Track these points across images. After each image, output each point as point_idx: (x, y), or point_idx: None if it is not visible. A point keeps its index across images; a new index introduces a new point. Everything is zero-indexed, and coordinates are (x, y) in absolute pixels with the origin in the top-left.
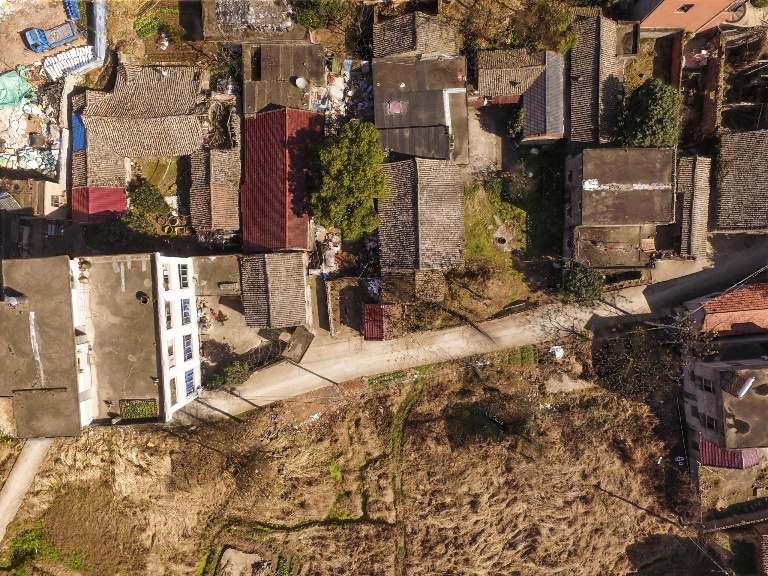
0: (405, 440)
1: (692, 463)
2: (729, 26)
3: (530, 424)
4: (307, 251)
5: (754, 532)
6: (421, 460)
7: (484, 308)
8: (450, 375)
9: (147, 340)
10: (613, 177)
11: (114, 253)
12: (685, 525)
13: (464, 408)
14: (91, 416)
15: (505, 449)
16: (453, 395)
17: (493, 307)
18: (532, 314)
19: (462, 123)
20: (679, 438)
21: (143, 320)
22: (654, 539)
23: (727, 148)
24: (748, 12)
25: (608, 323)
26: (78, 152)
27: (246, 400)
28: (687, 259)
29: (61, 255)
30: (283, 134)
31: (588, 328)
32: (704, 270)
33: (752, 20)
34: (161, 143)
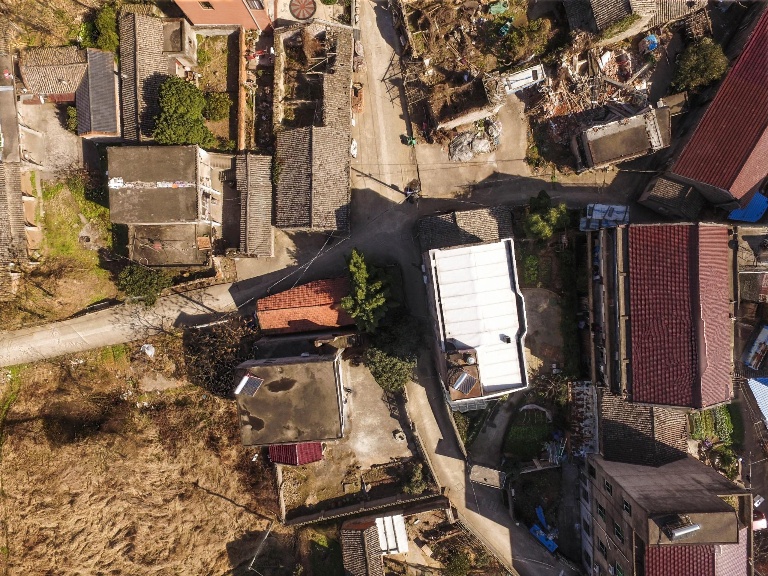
0: (4, 440)
1: None
2: None
3: (128, 423)
4: None
5: (334, 528)
6: (19, 460)
7: (61, 307)
8: (45, 374)
9: None
10: (137, 175)
11: None
12: (281, 521)
13: (62, 407)
14: None
15: (104, 448)
16: (50, 394)
17: (71, 306)
18: (121, 312)
19: (11, 121)
20: None
21: None
22: (251, 536)
23: (281, 146)
24: (318, 9)
25: (196, 321)
26: None
27: None
28: (251, 257)
29: None
30: None
31: (177, 326)
32: (287, 267)
33: (322, 17)
34: None
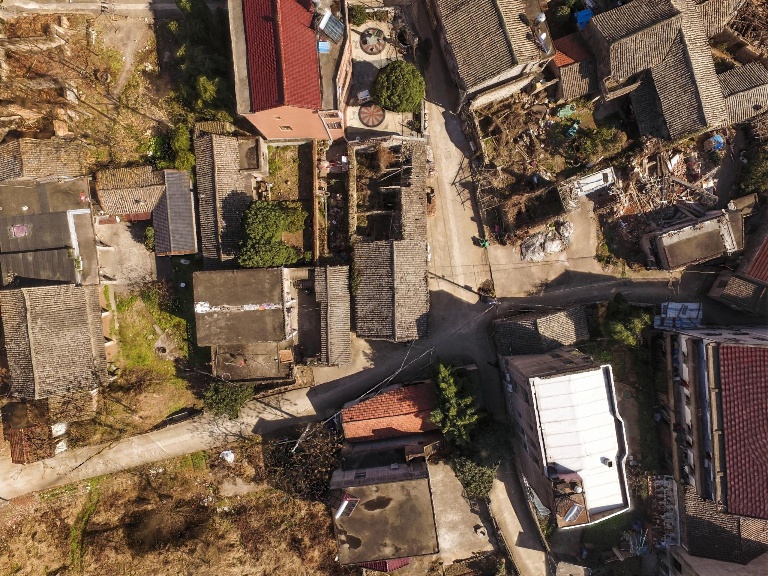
0: (84, 551)
1: None
2: (369, 131)
3: (209, 528)
4: None
5: None
6: (101, 570)
7: (141, 421)
8: (124, 484)
9: None
10: (224, 299)
11: None
12: None
13: (142, 516)
14: None
15: (185, 554)
16: (129, 504)
17: (151, 419)
18: (199, 421)
19: (89, 244)
20: None
21: None
22: None
23: (359, 257)
24: (387, 116)
25: (275, 426)
26: None
27: None
28: (332, 366)
29: None
30: None
31: (255, 432)
32: (364, 370)
33: (392, 124)
34: None
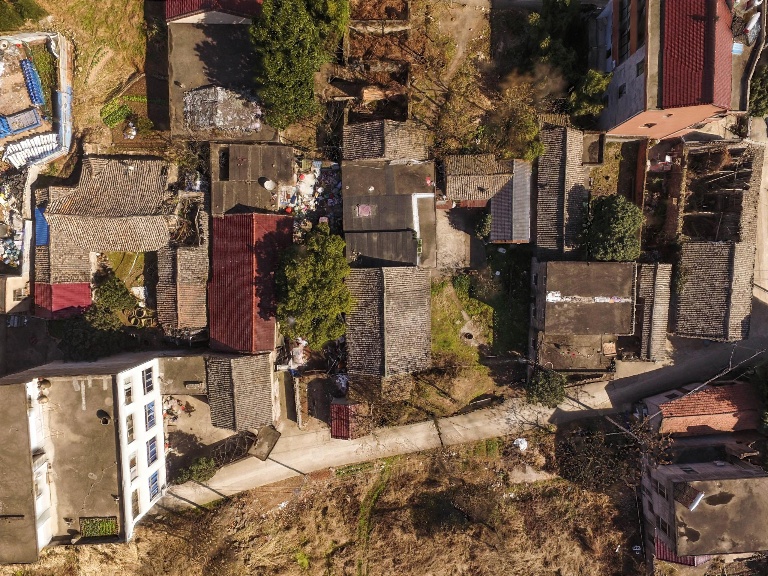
0: (371, 528)
1: (648, 553)
2: (693, 132)
3: (494, 513)
4: (275, 348)
5: None
6: (387, 548)
7: (450, 404)
8: (416, 465)
9: (108, 458)
10: (575, 290)
11: (77, 354)
12: None
13: (430, 497)
14: (50, 535)
15: (469, 537)
16: (419, 484)
17: (459, 403)
18: (497, 407)
19: (430, 227)
20: (636, 528)
21: (104, 439)
22: None
23: (687, 256)
24: None
25: (571, 417)
26: (41, 247)
27: (213, 490)
28: (647, 361)
29: (18, 383)
30: (250, 239)
31: (551, 422)
32: (664, 367)
33: (715, 127)
34: (127, 240)
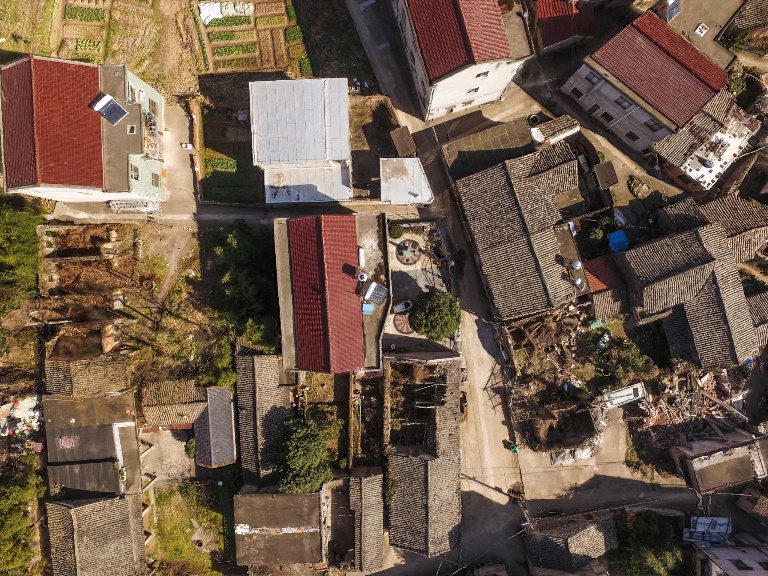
0: None
1: None
2: (404, 337)
3: None
4: None
5: None
6: None
7: None
8: None
9: None
10: (263, 522)
11: None
12: None
13: None
14: None
15: None
16: None
17: None
18: None
19: (133, 455)
20: None
21: None
22: None
23: (393, 468)
24: None
25: None
26: None
27: None
28: None
29: None
30: None
31: None
32: (395, 566)
33: None
34: None
